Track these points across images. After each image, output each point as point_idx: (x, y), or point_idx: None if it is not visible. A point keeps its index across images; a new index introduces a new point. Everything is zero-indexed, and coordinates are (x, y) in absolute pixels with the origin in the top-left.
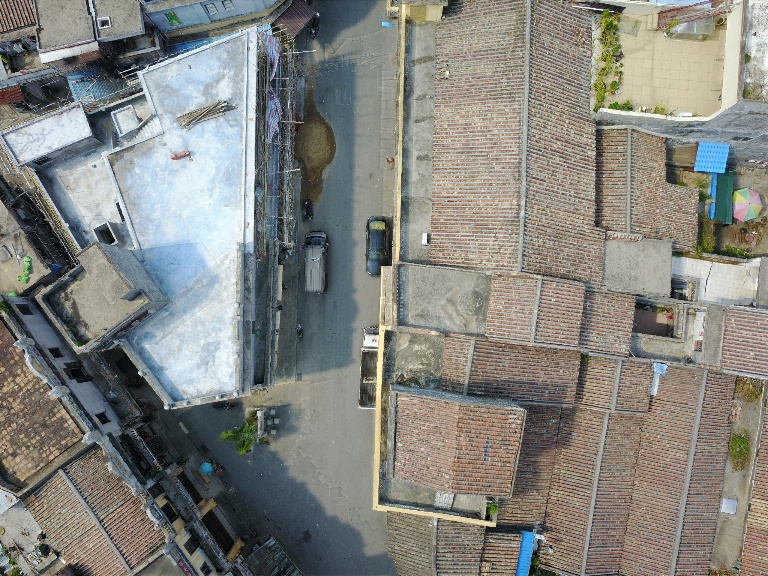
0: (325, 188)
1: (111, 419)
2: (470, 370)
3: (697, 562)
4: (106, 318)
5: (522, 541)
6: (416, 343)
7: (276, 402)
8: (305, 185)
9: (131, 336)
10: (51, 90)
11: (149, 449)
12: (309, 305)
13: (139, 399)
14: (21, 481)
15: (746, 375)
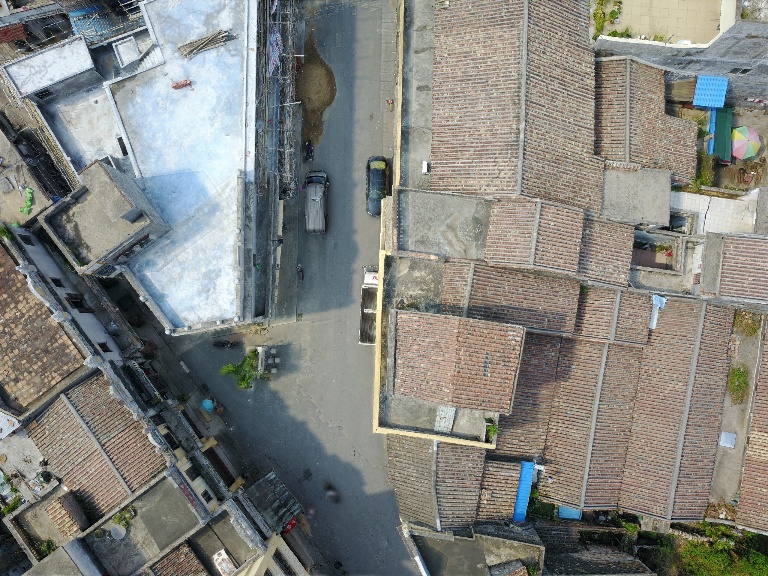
0: (325, 130)
1: (112, 350)
2: (470, 293)
3: (696, 494)
4: (108, 240)
5: (521, 471)
6: (416, 269)
7: (277, 342)
8: (306, 127)
9: (132, 264)
10: (53, 32)
11: (150, 382)
12: (309, 246)
13: (140, 337)
14: (23, 406)
15: (744, 300)
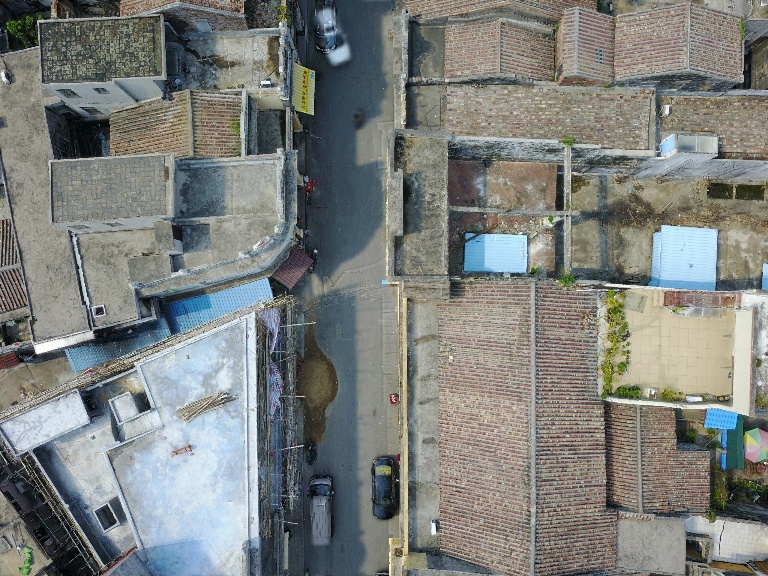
0: (328, 427)
1: None
2: None
3: None
4: None
5: None
6: None
7: None
8: (308, 424)
9: None
10: None
11: None
12: (316, 549)
13: None
14: None
15: None
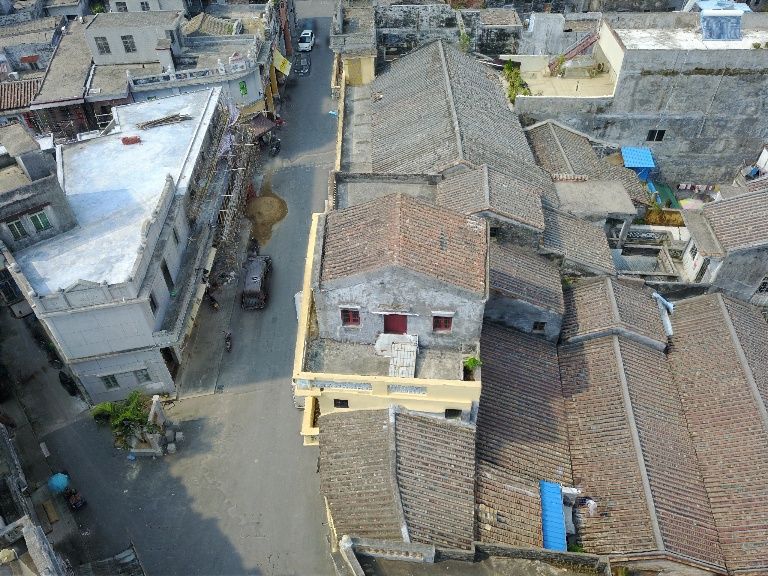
0: (274, 236)
1: None
2: None
3: None
4: None
5: (542, 494)
6: None
7: (183, 417)
8: (254, 235)
9: (19, 255)
10: None
11: None
12: (244, 322)
13: None
14: None
15: (755, 244)
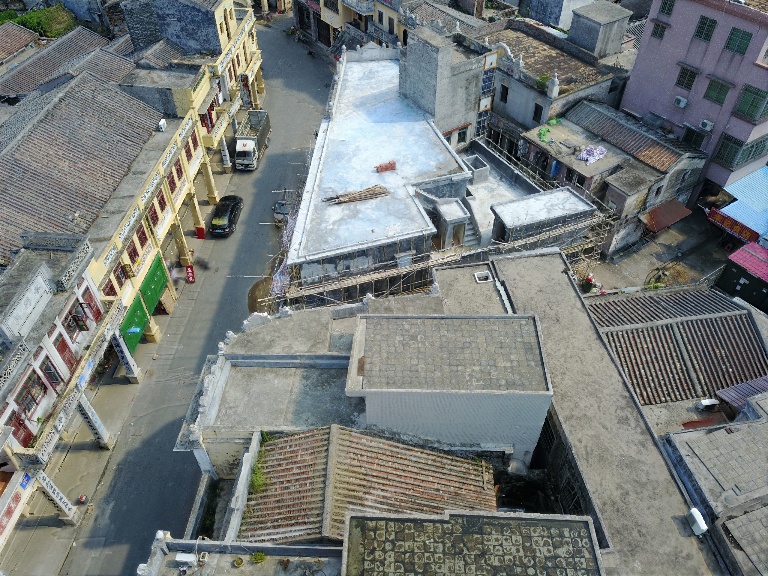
0: None
1: None
2: None
3: None
4: None
5: None
6: None
7: None
8: None
9: None
10: None
11: None
12: None
13: None
14: None
15: None
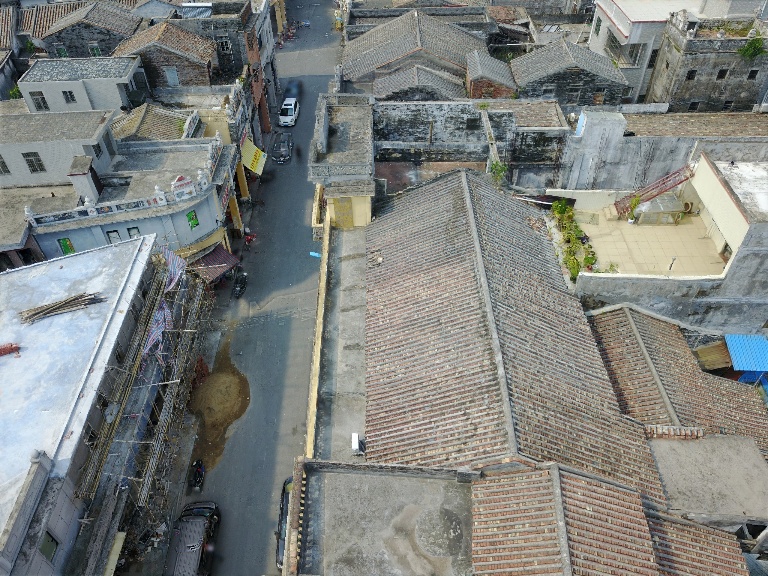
0: (228, 449)
1: None
2: None
3: None
4: None
5: None
6: None
7: None
8: (199, 446)
9: None
10: None
11: None
12: None
13: None
14: None
15: None
